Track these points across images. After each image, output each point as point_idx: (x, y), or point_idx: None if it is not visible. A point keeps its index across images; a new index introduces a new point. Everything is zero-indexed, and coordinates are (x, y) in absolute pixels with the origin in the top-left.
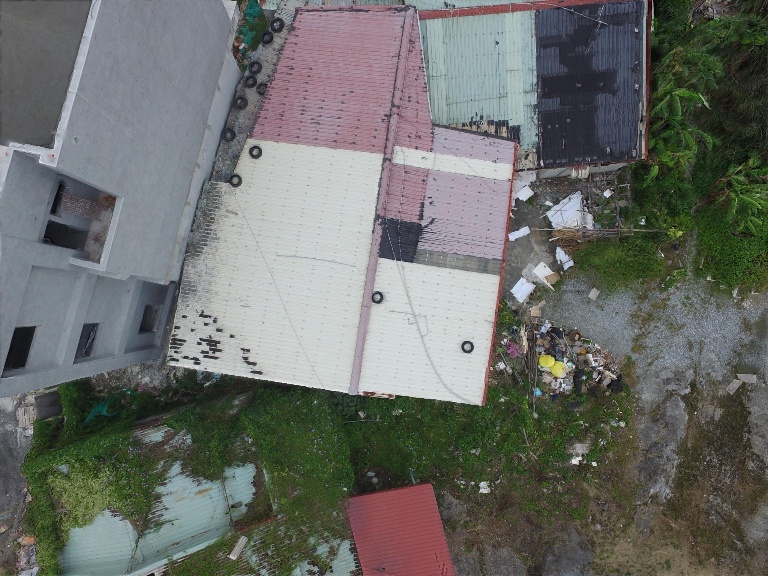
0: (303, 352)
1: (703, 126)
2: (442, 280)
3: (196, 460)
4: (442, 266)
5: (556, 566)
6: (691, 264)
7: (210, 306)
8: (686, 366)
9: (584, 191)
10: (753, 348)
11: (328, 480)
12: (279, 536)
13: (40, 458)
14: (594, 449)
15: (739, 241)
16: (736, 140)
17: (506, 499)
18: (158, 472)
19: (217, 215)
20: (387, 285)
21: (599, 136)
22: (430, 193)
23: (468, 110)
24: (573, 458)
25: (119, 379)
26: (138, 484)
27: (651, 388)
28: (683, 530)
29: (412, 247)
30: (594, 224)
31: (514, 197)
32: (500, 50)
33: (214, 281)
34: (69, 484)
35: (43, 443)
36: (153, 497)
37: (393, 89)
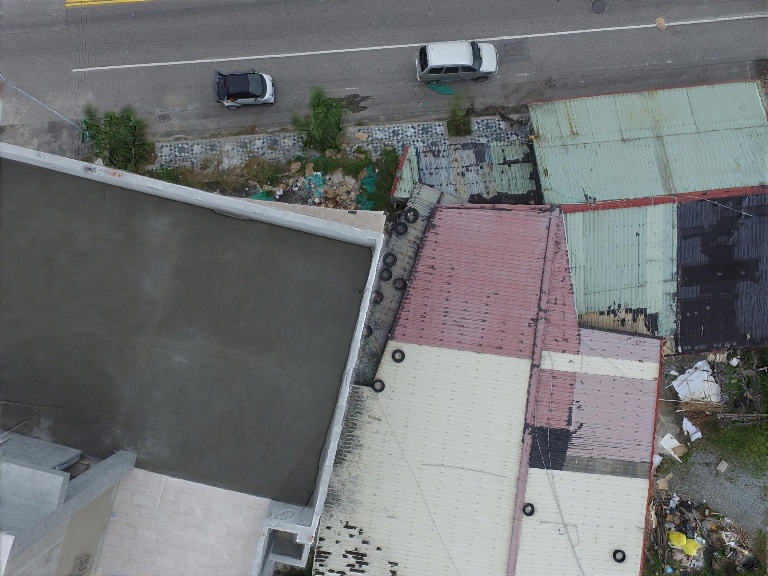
0: (454, 567)
1: None
2: (592, 487)
3: None
4: (591, 472)
5: None
6: None
7: (355, 517)
8: None
9: None
10: None
11: None
12: None
13: None
14: None
15: None
16: None
17: None
18: None
19: (359, 421)
20: (538, 495)
21: (739, 323)
22: (578, 397)
23: (606, 299)
24: None
25: None
26: None
27: None
28: None
29: (561, 454)
30: (721, 394)
31: None
32: (640, 241)
33: (358, 490)
34: None
35: None
36: None
37: (539, 292)
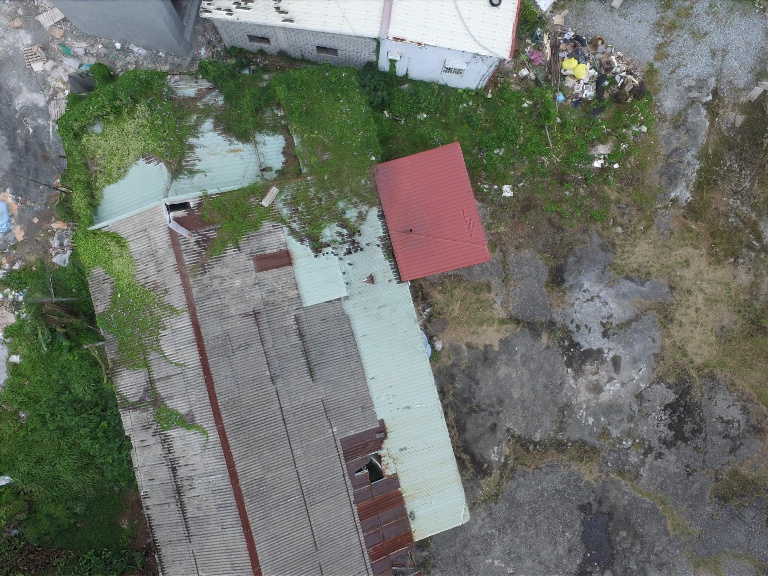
0: None
1: None
2: None
3: (228, 116)
4: None
5: (577, 266)
6: None
7: None
8: (708, 74)
9: None
10: None
11: (356, 148)
12: (309, 196)
13: None
14: (616, 150)
15: None
16: None
17: (529, 201)
18: (191, 125)
19: None
20: None
21: None
22: None
23: None
24: (595, 160)
25: None
26: (172, 129)
27: (673, 96)
28: (703, 232)
29: None
30: None
31: None
32: None
33: None
34: (104, 139)
35: None
36: (187, 147)
37: None
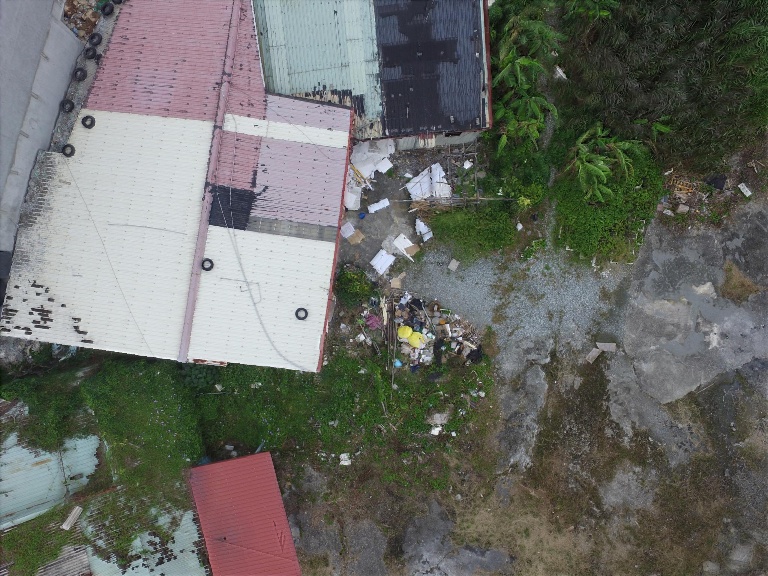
0: (133, 320)
1: (560, 97)
2: (276, 247)
3: (31, 431)
4: (276, 233)
5: (416, 537)
6: (550, 234)
7: (42, 276)
8: (546, 336)
9: (443, 163)
10: (612, 317)
11: (171, 451)
12: (118, 507)
13: None
14: (452, 419)
15: (593, 210)
16: (588, 109)
17: (366, 471)
18: None
19: (50, 185)
20: (218, 252)
21: (442, 105)
22: (263, 161)
23: (310, 80)
24: (432, 428)
25: None
26: None
27: (511, 358)
28: (543, 499)
29: (244, 214)
30: (453, 195)
31: (373, 169)
32: (339, 19)
33: (47, 251)
34: None
35: None
36: None
37: (224, 57)
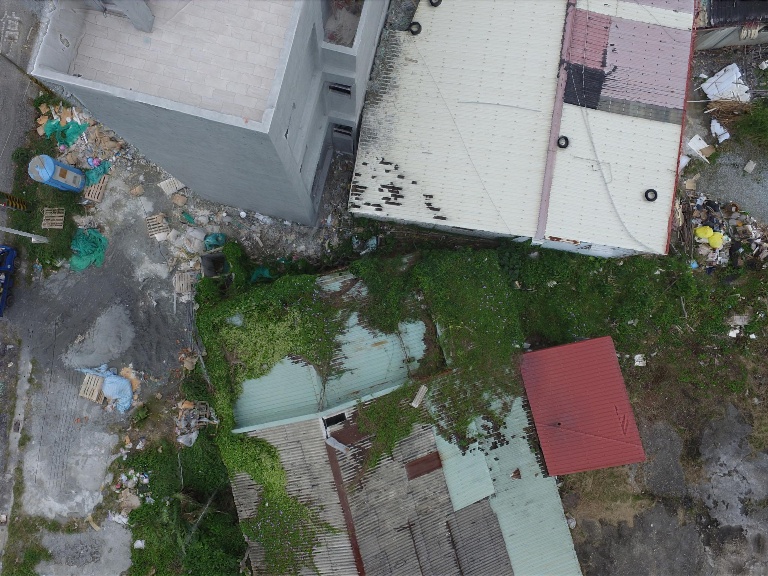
0: (488, 197)
1: None
2: (625, 128)
3: (374, 310)
4: (625, 114)
5: (713, 439)
6: None
7: (391, 153)
8: None
9: (739, 63)
10: None
11: (500, 337)
12: (455, 390)
13: (222, 303)
14: (753, 320)
15: None
16: None
17: (662, 372)
18: (337, 321)
19: (396, 63)
20: (572, 131)
21: None
22: (613, 40)
23: None
24: (731, 330)
25: (274, 248)
26: (321, 329)
27: None
28: None
29: (596, 93)
30: None
31: None
32: None
33: (394, 128)
34: (246, 334)
35: (215, 296)
36: (333, 345)
37: None
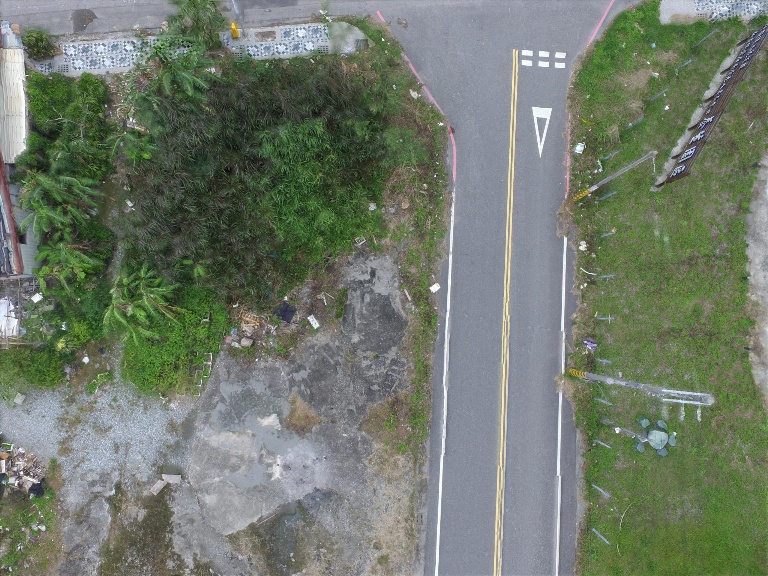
0: None
1: None
2: None
3: None
4: None
5: None
6: (119, 367)
7: None
8: (112, 468)
9: (12, 296)
10: (179, 449)
11: None
12: None
13: None
14: (6, 555)
15: (149, 346)
16: None
17: None
18: None
19: None
20: None
21: None
22: None
23: None
24: None
25: None
26: None
27: (76, 491)
28: None
29: None
30: (20, 329)
31: None
32: None
33: None
34: None
35: None
36: None
37: None
